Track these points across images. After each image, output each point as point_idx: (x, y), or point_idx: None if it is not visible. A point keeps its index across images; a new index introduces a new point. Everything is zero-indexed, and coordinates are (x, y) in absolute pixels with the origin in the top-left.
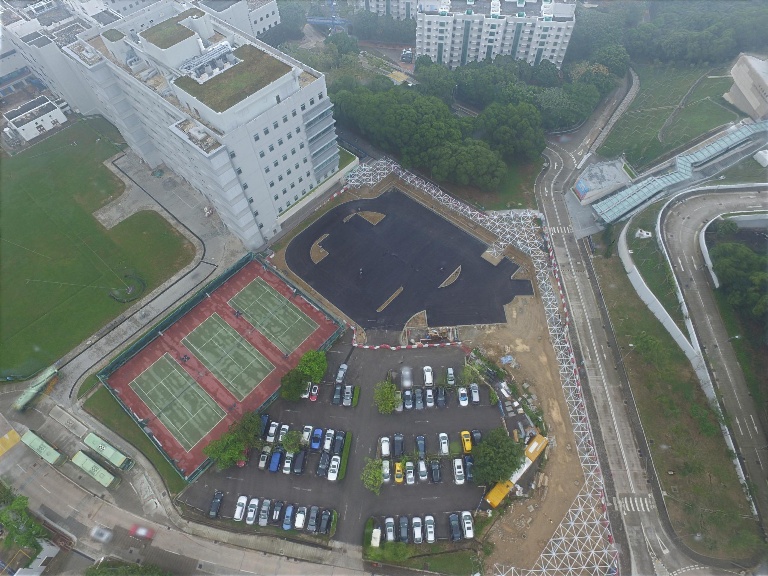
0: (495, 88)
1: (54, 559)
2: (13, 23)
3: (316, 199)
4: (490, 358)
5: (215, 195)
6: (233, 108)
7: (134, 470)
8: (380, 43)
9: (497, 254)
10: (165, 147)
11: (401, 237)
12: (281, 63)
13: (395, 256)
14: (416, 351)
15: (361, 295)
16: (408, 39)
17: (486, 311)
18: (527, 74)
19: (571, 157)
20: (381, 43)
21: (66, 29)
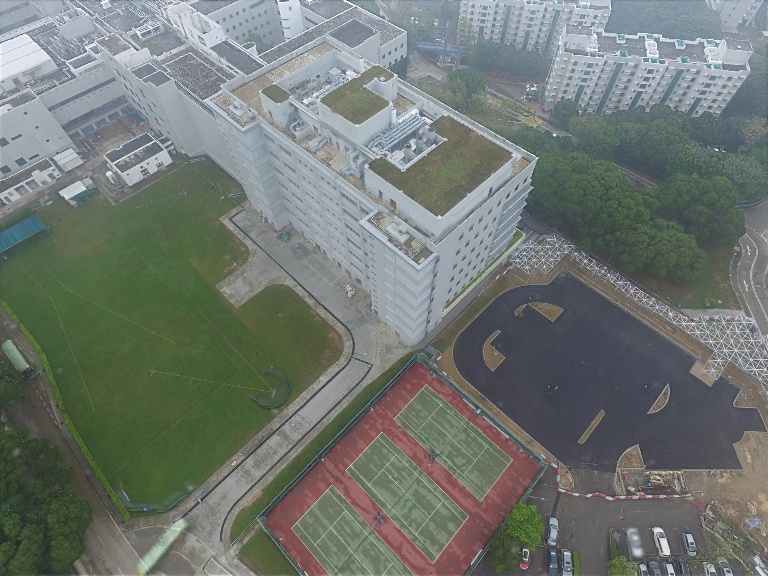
0: (669, 150)
1: None
2: (122, 52)
3: (478, 283)
4: (731, 519)
5: (389, 292)
6: (453, 209)
7: None
8: (499, 76)
9: (717, 375)
10: (307, 215)
11: (588, 340)
12: (496, 146)
13: (586, 366)
14: (637, 503)
15: (555, 418)
16: (533, 74)
17: (713, 451)
18: (690, 129)
19: (764, 240)
20: (500, 76)
21: (178, 60)
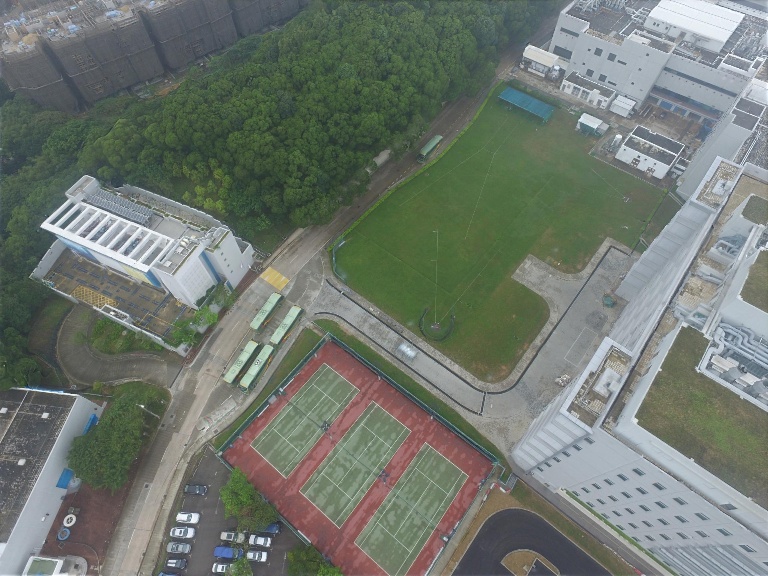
0: None
1: (178, 355)
2: (765, 82)
3: None
4: None
5: None
6: (657, 439)
7: (242, 395)
8: None
9: None
10: (634, 308)
11: None
12: None
13: None
14: None
15: None
16: None
17: None
18: None
19: None
20: None
21: None
